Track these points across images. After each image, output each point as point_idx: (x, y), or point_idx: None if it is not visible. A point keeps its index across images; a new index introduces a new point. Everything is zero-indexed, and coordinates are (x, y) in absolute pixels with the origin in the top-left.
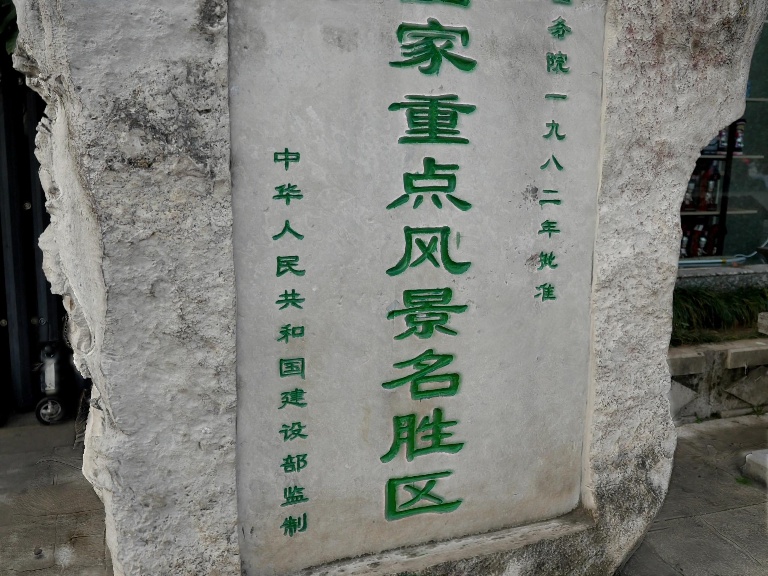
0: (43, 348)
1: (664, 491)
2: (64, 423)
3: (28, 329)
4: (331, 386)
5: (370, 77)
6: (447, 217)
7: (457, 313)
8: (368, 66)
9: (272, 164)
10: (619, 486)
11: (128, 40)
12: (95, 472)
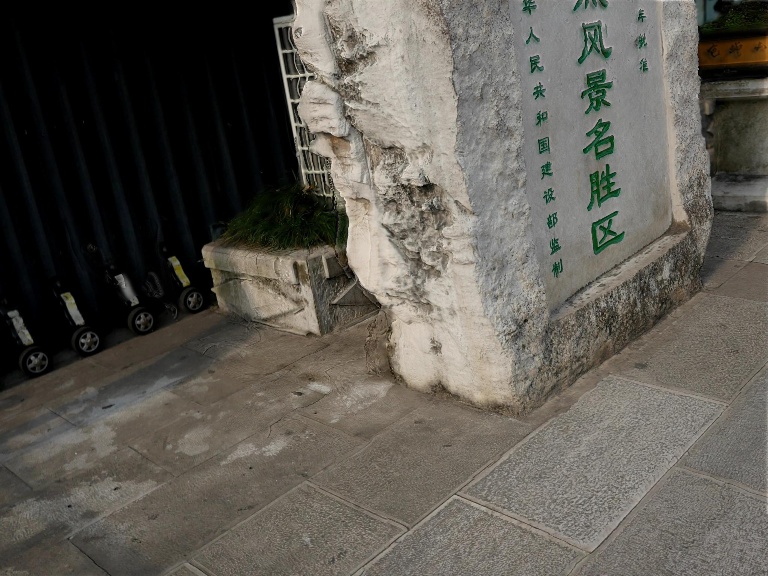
0: (105, 272)
1: (711, 199)
2: (185, 322)
3: (84, 257)
4: (562, 156)
5: None
6: (600, 13)
7: (609, 88)
8: None
9: None
10: (693, 201)
11: None
12: (398, 280)
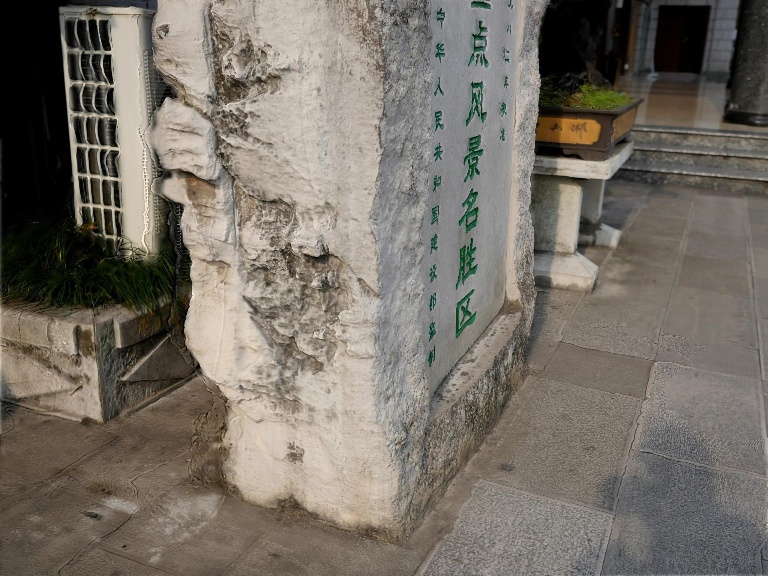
0: None
1: None
2: None
3: None
4: (445, 228)
5: None
6: None
7: (480, 156)
8: None
9: (436, 23)
10: (523, 279)
11: None
12: (259, 369)
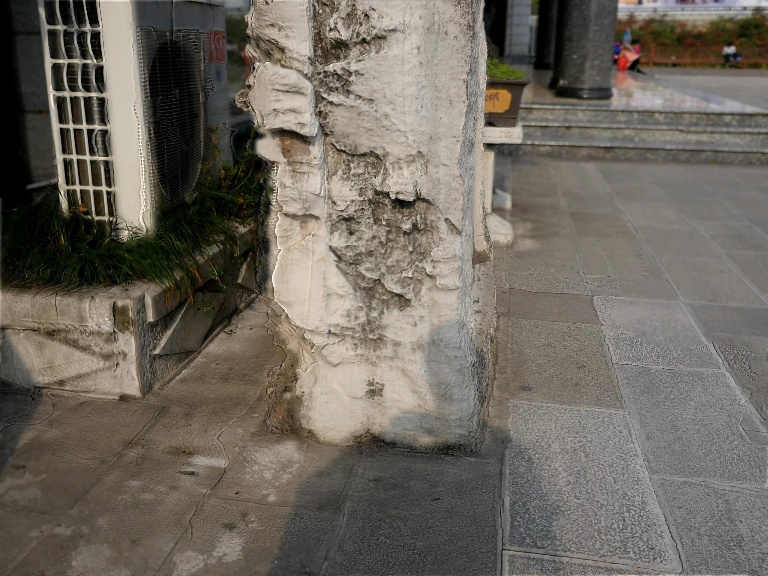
0: None
1: None
2: None
3: None
4: None
5: None
6: None
7: None
8: None
9: None
10: (484, 232)
11: None
12: (348, 313)
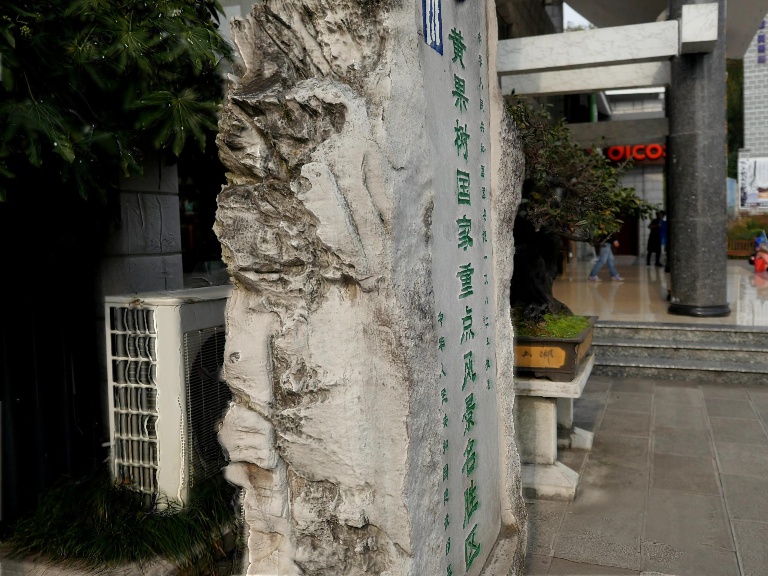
0: None
1: None
2: None
3: None
4: (452, 480)
5: None
6: None
7: None
8: (453, 249)
9: (437, 324)
10: (515, 503)
11: (409, 246)
12: None
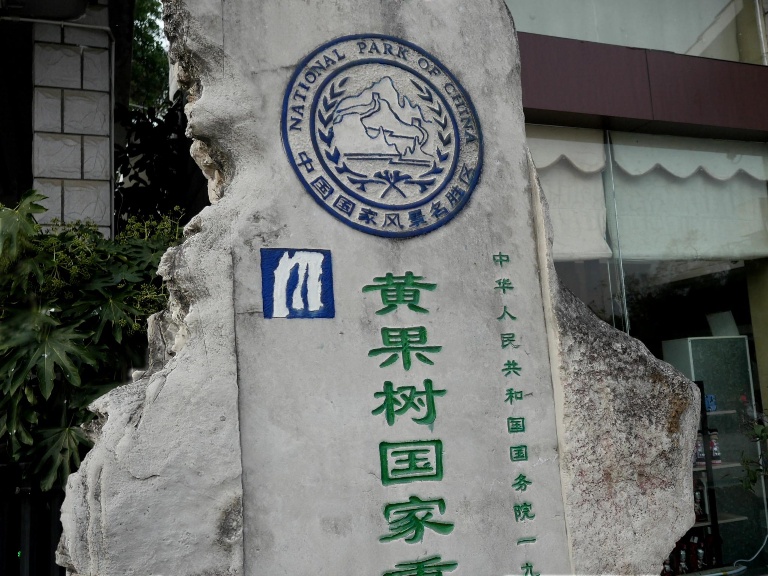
0: None
1: None
2: None
3: None
4: None
5: (364, 556)
6: None
7: None
8: (362, 546)
9: None
10: None
11: (160, 563)
12: None
